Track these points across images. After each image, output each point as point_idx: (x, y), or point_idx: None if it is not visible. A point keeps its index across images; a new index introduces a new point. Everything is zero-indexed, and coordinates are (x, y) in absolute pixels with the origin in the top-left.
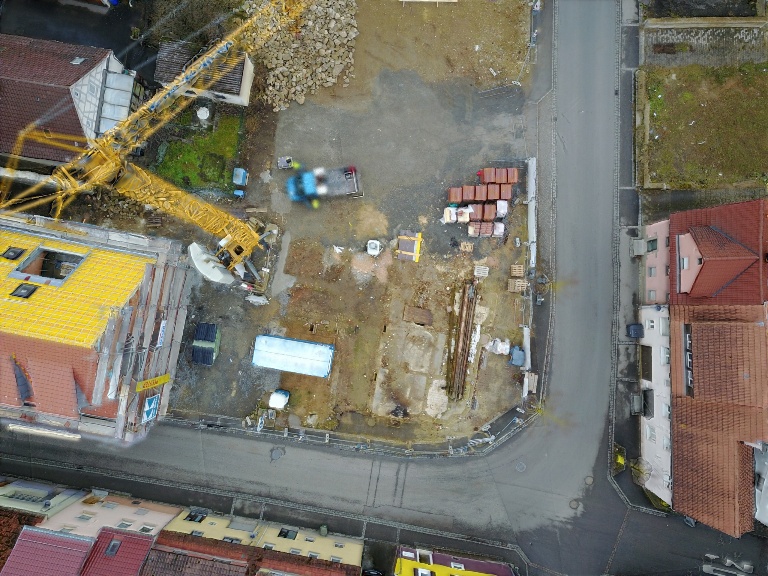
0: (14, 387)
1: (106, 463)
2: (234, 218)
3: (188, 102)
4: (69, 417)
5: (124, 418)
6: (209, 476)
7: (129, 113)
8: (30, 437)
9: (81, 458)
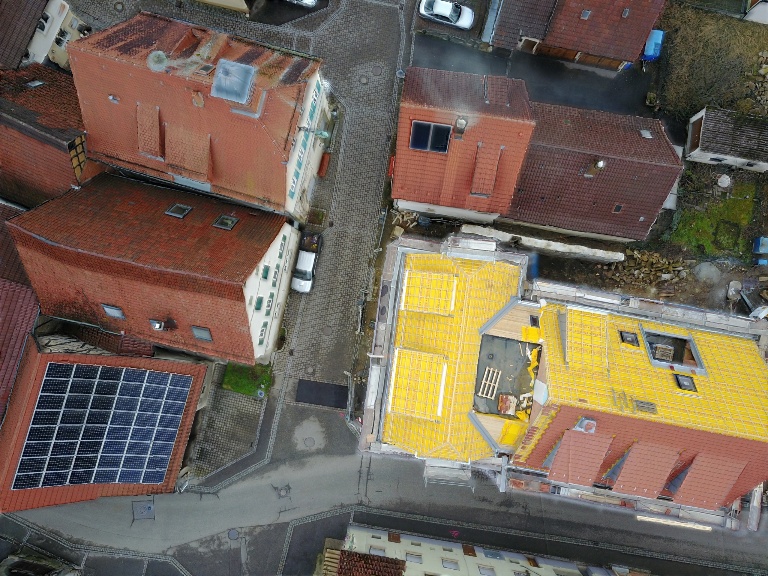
0: (662, 481)
1: (622, 539)
2: (747, 287)
3: (702, 169)
4: (707, 510)
5: (759, 510)
6: (728, 552)
7: (678, 185)
8: (544, 513)
9: (597, 534)
